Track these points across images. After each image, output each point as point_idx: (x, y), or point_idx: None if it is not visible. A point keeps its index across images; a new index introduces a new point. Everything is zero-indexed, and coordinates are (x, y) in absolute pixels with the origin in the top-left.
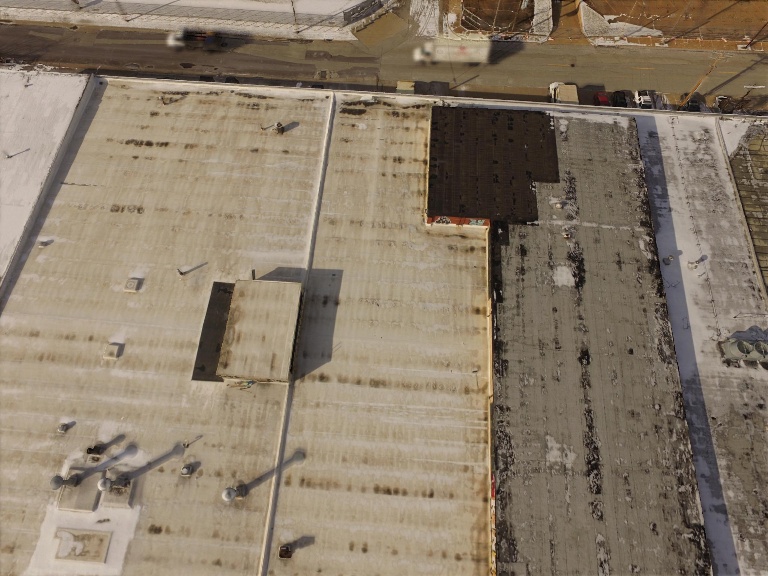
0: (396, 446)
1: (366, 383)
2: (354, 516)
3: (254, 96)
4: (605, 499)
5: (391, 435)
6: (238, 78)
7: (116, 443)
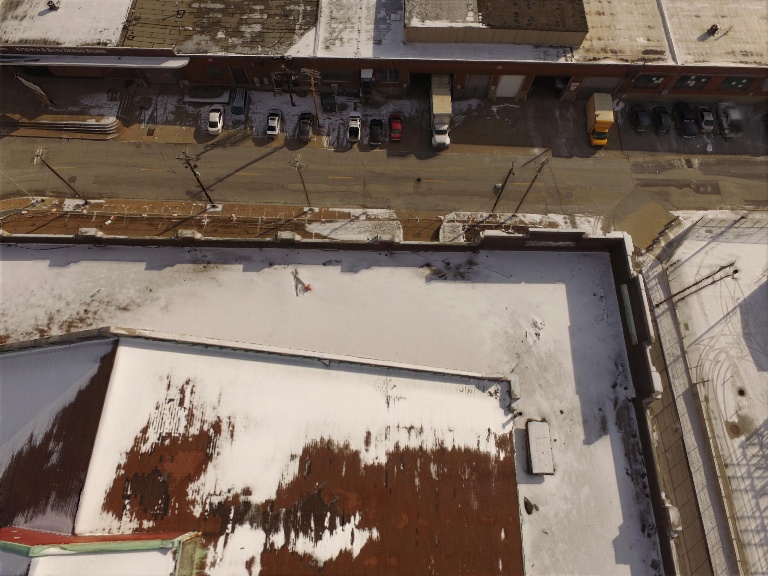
0: None
1: None
2: None
3: (752, 63)
4: None
5: None
6: None
7: None
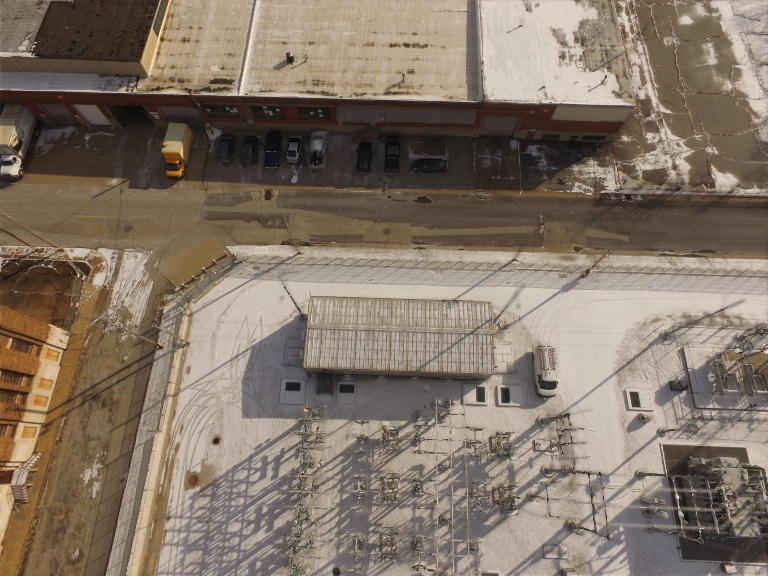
0: None
1: None
2: None
3: (319, 93)
4: None
5: None
6: (362, 185)
7: None
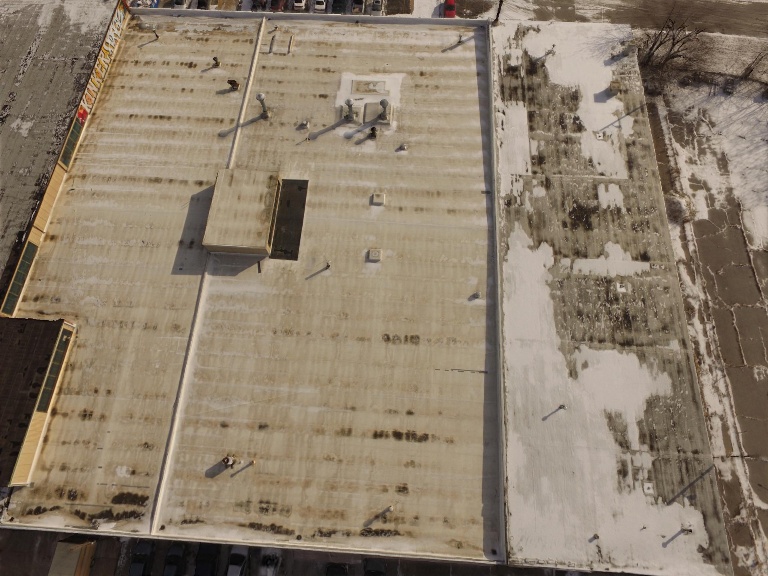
0: (150, 142)
1: (165, 180)
2: (188, 105)
3: (267, 528)
4: (3, 103)
5: (152, 148)
6: None
7: (361, 140)
